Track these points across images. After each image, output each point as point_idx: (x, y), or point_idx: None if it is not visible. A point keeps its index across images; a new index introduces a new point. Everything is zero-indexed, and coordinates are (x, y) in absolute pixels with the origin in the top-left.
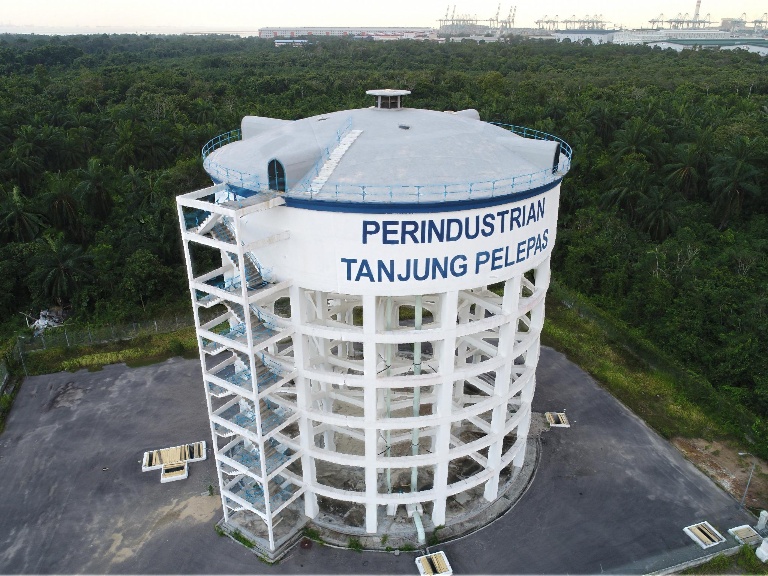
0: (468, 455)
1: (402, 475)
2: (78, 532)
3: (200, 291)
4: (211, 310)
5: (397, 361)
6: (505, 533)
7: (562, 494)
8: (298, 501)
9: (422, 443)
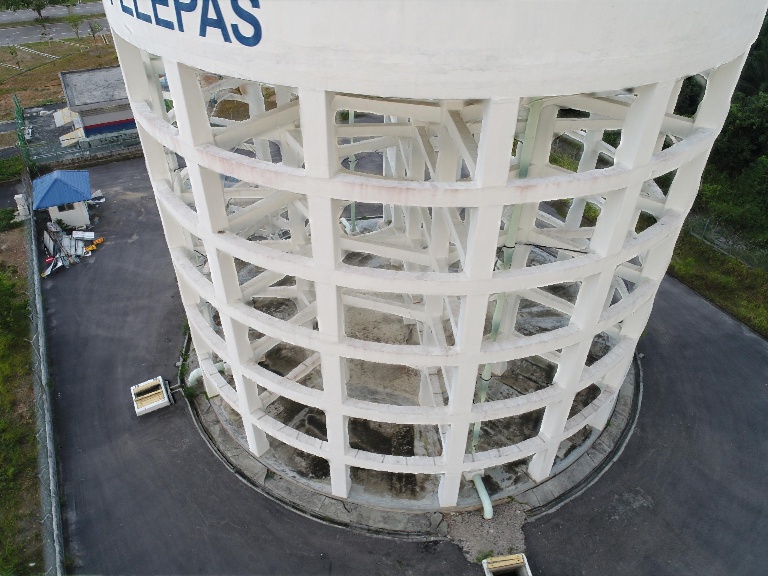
0: (354, 420)
1: (299, 349)
2: (227, 180)
3: (618, 130)
4: (601, 155)
5: (418, 245)
6: (199, 474)
7: (283, 567)
8: (251, 274)
9: (367, 362)
